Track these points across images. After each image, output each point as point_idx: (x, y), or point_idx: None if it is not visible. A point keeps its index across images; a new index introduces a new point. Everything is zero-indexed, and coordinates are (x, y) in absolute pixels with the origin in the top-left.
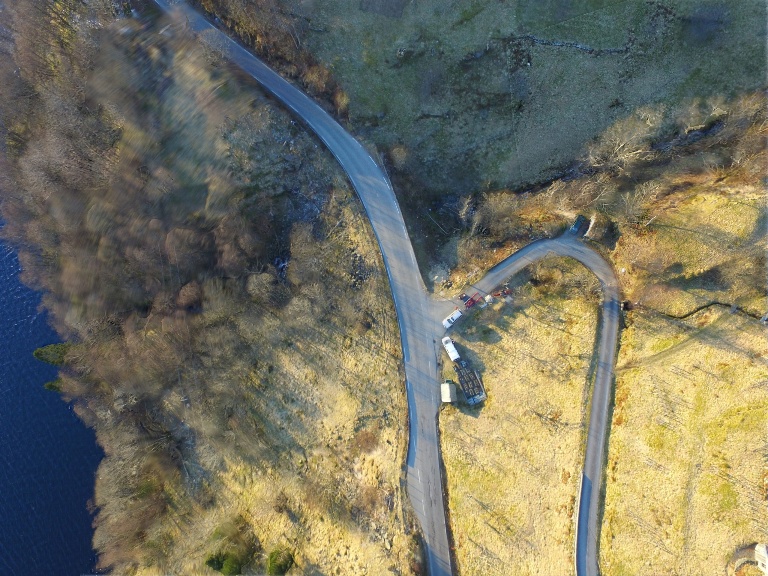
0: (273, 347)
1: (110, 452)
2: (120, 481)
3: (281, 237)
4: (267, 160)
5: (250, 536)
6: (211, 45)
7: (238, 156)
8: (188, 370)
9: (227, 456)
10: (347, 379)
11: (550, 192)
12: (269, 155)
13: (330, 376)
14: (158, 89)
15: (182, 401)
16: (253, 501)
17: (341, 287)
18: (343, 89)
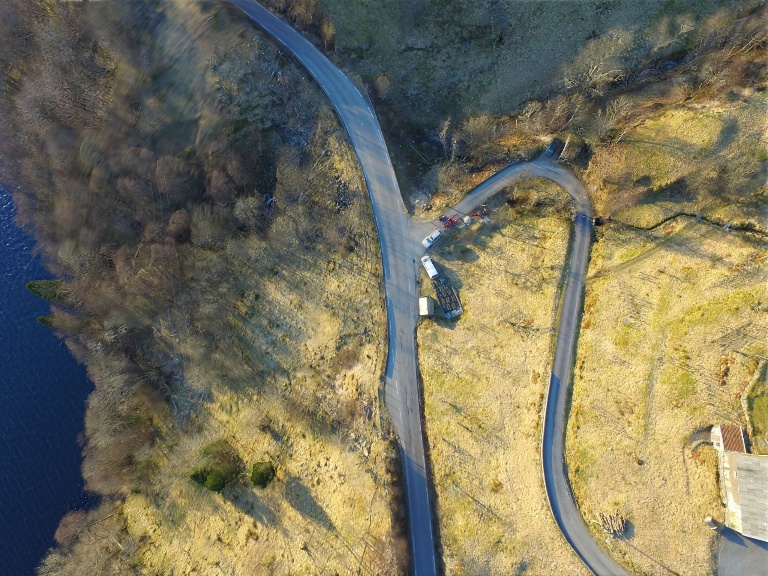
0: (260, 276)
1: (100, 385)
2: (109, 408)
3: (269, 173)
4: (256, 92)
5: (235, 459)
6: None
7: (227, 88)
8: (177, 305)
9: (214, 388)
10: (330, 300)
11: (527, 114)
12: (258, 87)
13: (314, 300)
14: (151, 25)
15: (171, 336)
16: (239, 428)
17: (326, 215)
18: (329, 20)
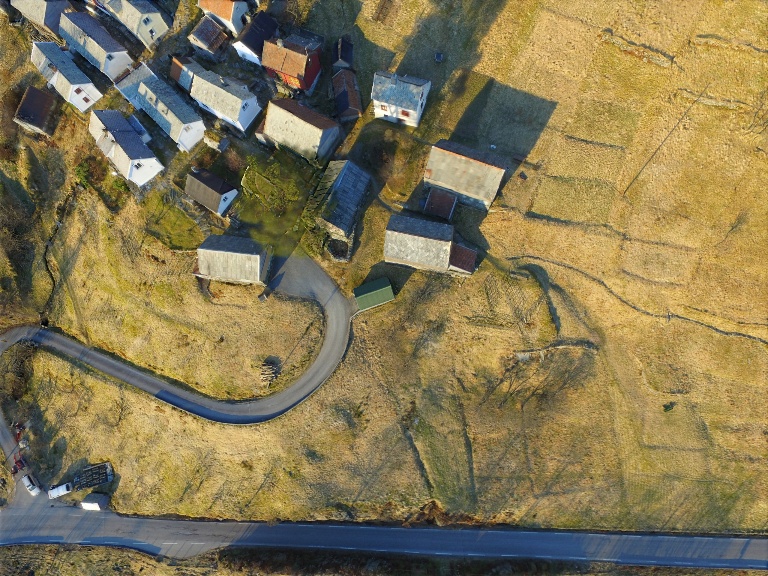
0: None
1: None
2: None
3: None
4: None
5: None
6: None
7: None
8: None
9: None
10: None
11: None
12: None
13: None
14: None
15: None
16: None
17: None
18: None
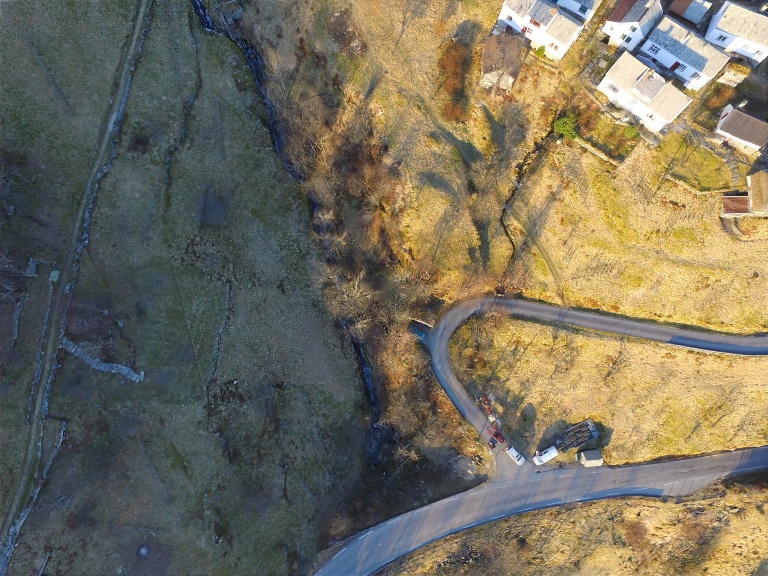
0: None
1: None
2: None
3: None
4: None
5: None
6: None
7: None
8: None
9: None
10: (576, 560)
11: None
12: None
13: (569, 575)
14: None
15: None
16: None
17: (474, 571)
18: None
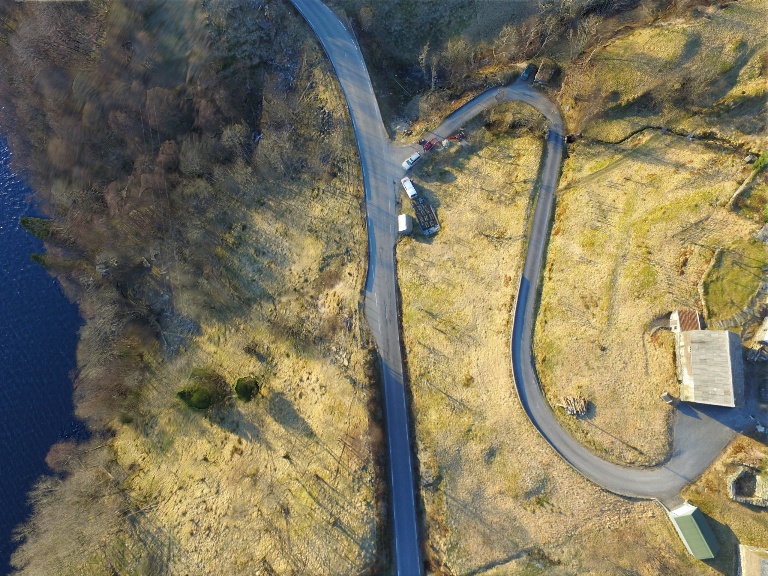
0: (247, 208)
1: (92, 321)
2: (100, 339)
3: (257, 111)
4: (244, 28)
5: (222, 385)
6: None
7: (216, 24)
8: (168, 242)
9: (203, 322)
10: (314, 224)
11: (503, 39)
12: (245, 22)
13: (299, 227)
14: None
15: (162, 274)
16: (226, 357)
17: (311, 146)
18: None
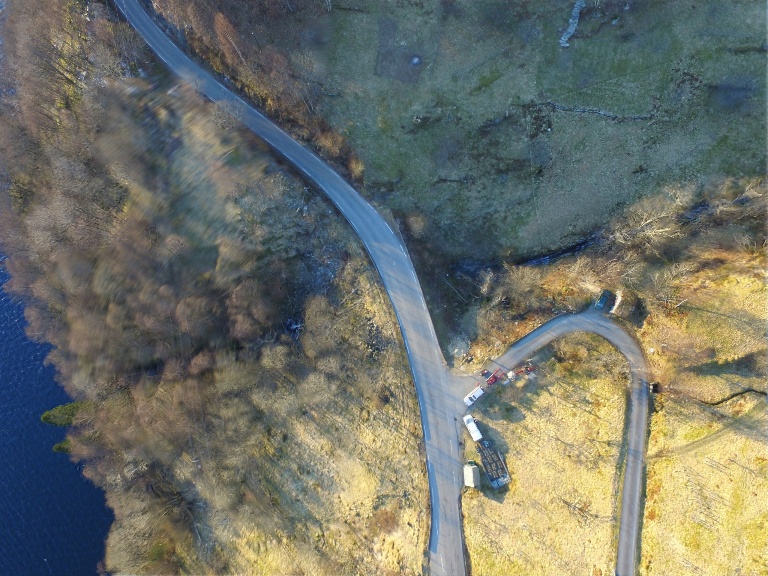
0: (287, 414)
1: (120, 515)
2: (131, 550)
3: (293, 298)
4: (279, 225)
5: None
6: (221, 107)
7: (250, 221)
8: (199, 432)
9: None
10: (365, 455)
11: (574, 267)
12: (281, 220)
13: (347, 449)
14: (166, 150)
15: (193, 462)
16: (268, 571)
17: (357, 356)
18: (358, 155)
